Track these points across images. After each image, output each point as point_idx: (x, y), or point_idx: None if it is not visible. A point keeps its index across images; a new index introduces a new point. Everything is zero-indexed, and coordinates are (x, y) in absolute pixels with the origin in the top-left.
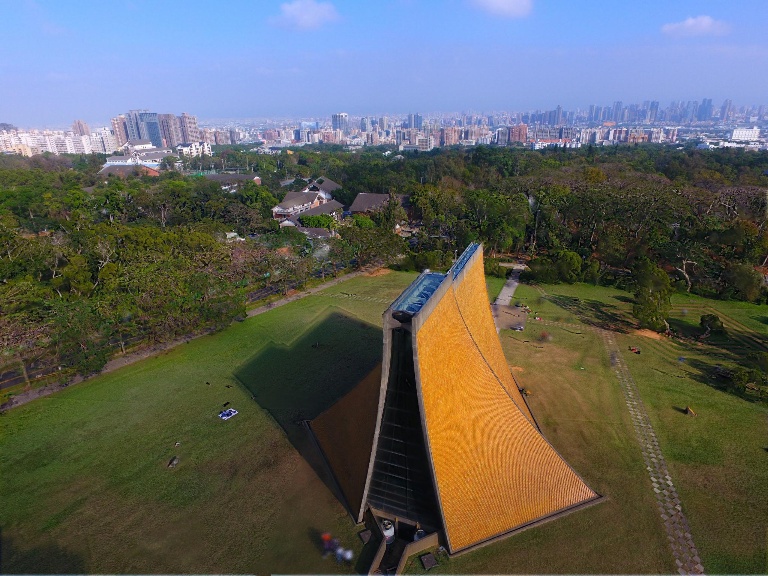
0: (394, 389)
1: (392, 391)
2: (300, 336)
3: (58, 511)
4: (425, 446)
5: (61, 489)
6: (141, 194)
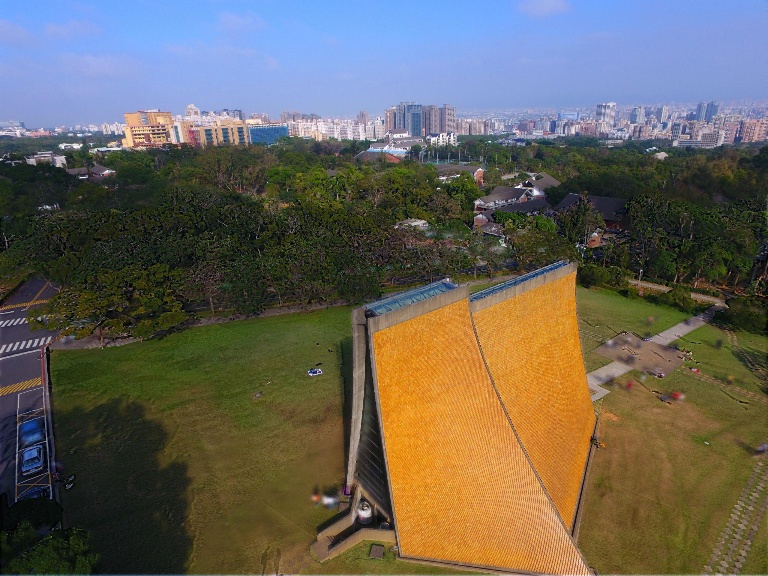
0: (369, 382)
1: (368, 383)
2: None
3: (177, 401)
4: None
5: (187, 388)
6: (364, 178)
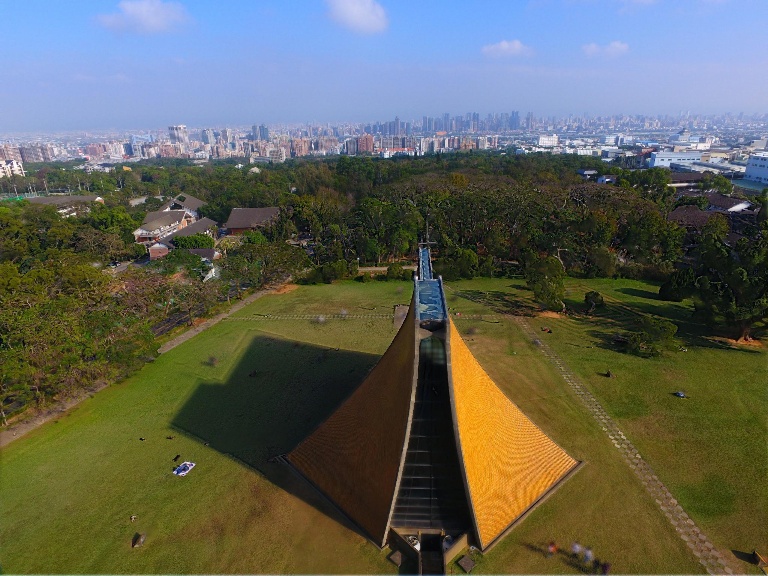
0: (420, 400)
1: (417, 402)
2: (230, 367)
3: None
4: (457, 450)
5: None
6: None
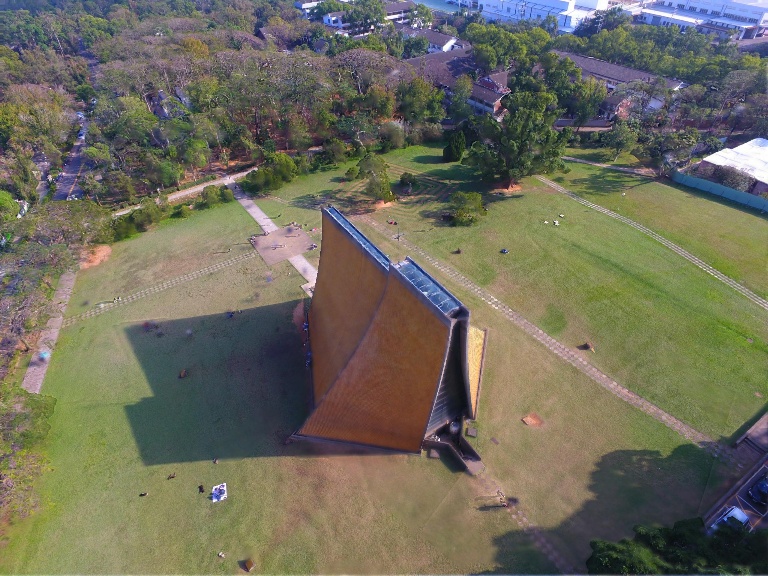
0: None
1: None
2: (147, 378)
3: None
4: (466, 377)
5: None
6: None
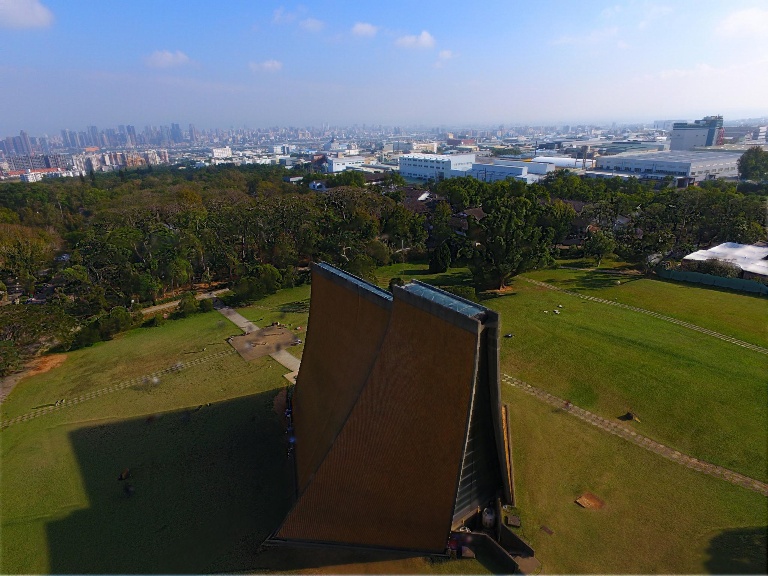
0: None
1: None
2: (75, 483)
3: None
4: (500, 425)
5: None
6: None
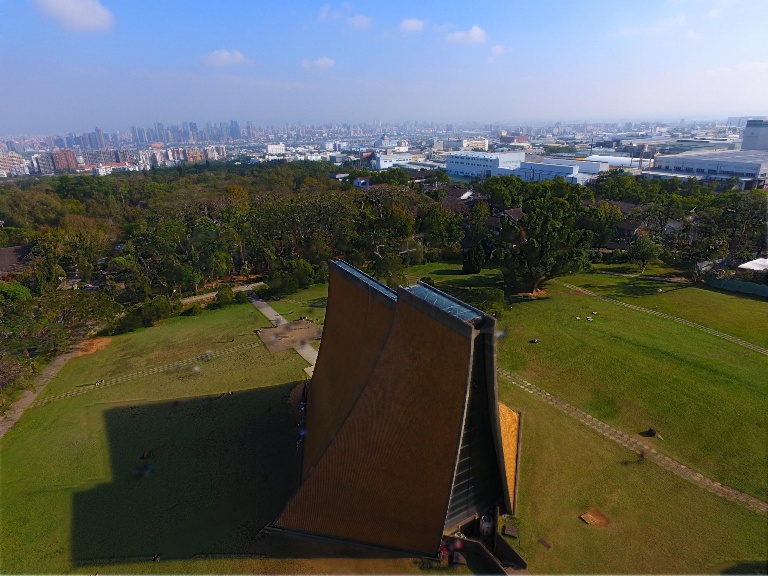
0: None
1: None
2: (103, 458)
3: None
4: (497, 432)
5: None
6: None
